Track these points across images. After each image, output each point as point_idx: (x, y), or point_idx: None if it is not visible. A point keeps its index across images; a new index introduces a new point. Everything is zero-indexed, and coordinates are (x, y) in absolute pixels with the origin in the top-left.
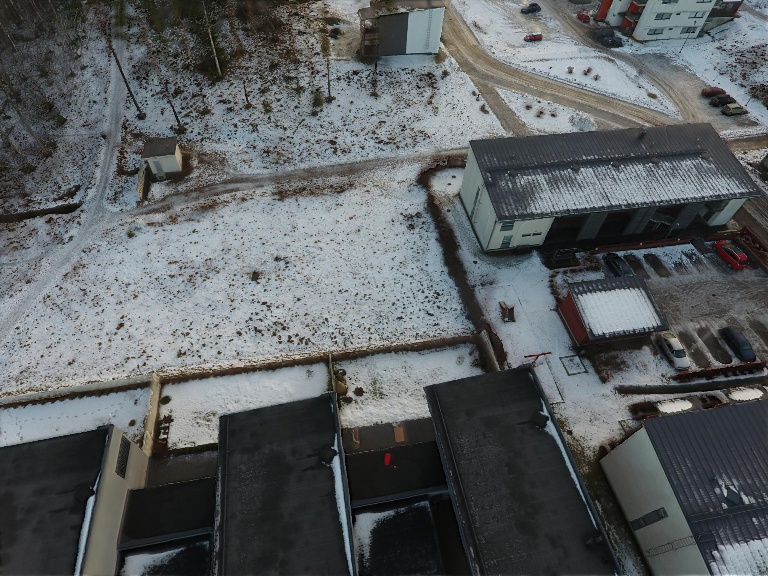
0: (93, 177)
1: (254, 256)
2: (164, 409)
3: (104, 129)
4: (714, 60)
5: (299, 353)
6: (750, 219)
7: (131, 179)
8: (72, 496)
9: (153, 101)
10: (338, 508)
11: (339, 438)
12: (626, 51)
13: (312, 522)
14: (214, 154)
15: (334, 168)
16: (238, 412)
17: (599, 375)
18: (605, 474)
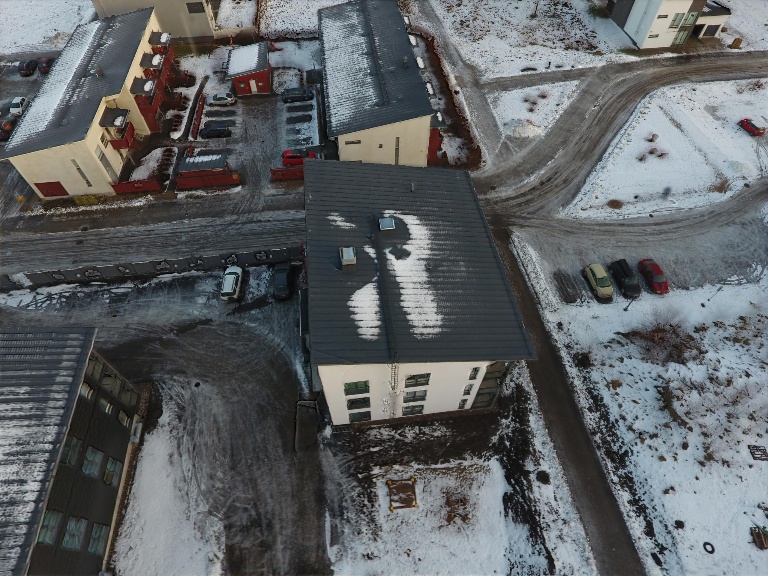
0: None
1: None
2: None
3: None
4: None
5: None
6: None
7: None
8: None
9: None
10: None
11: None
12: None
13: None
14: None
15: (429, 8)
16: None
17: (218, 72)
18: None
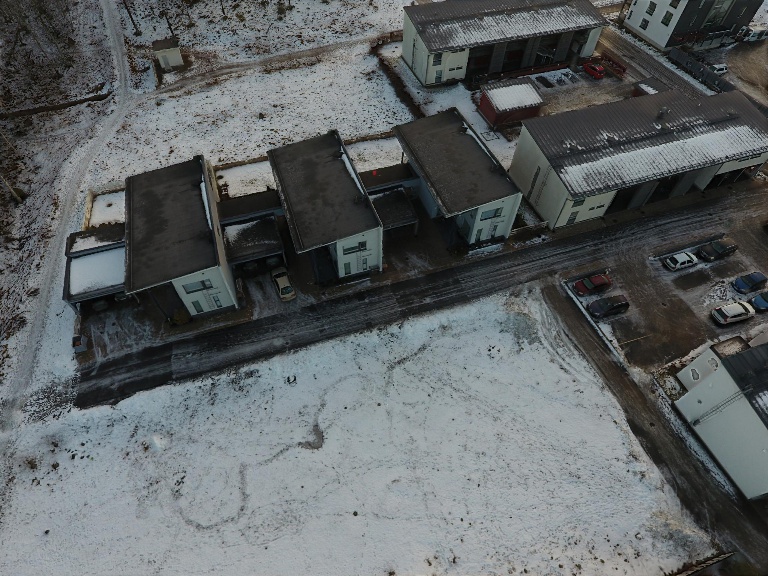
0: (114, 75)
1: (257, 106)
2: (221, 181)
3: (110, 45)
4: None
5: None
6: (610, 52)
7: (145, 73)
8: (190, 185)
9: (144, 22)
10: (350, 172)
11: None
12: None
13: (336, 180)
14: (206, 52)
15: (304, 52)
16: (278, 148)
17: (507, 139)
18: None
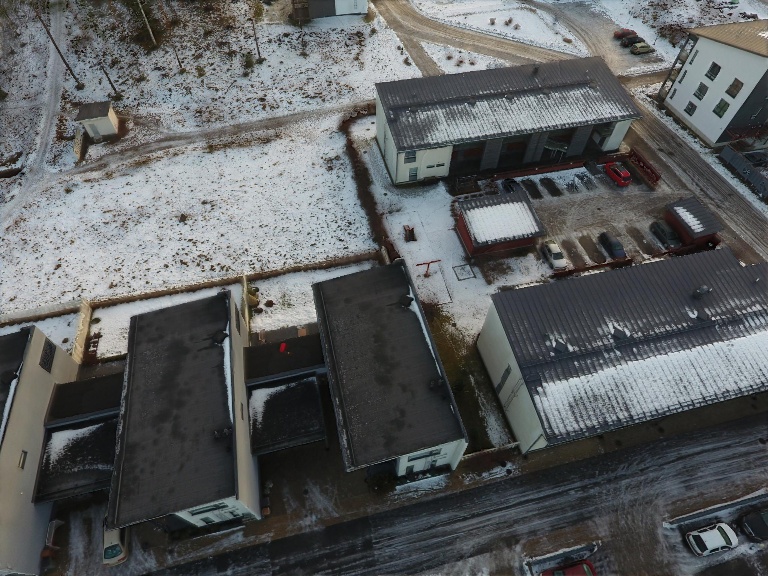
0: (33, 143)
1: (183, 202)
2: (94, 328)
3: (44, 100)
4: (629, 5)
5: (219, 278)
6: (642, 143)
7: (70, 143)
8: None
9: (91, 72)
10: (225, 375)
11: (230, 324)
12: (548, 1)
13: (203, 386)
14: (149, 117)
15: (262, 122)
16: None
17: (486, 279)
18: (480, 354)
